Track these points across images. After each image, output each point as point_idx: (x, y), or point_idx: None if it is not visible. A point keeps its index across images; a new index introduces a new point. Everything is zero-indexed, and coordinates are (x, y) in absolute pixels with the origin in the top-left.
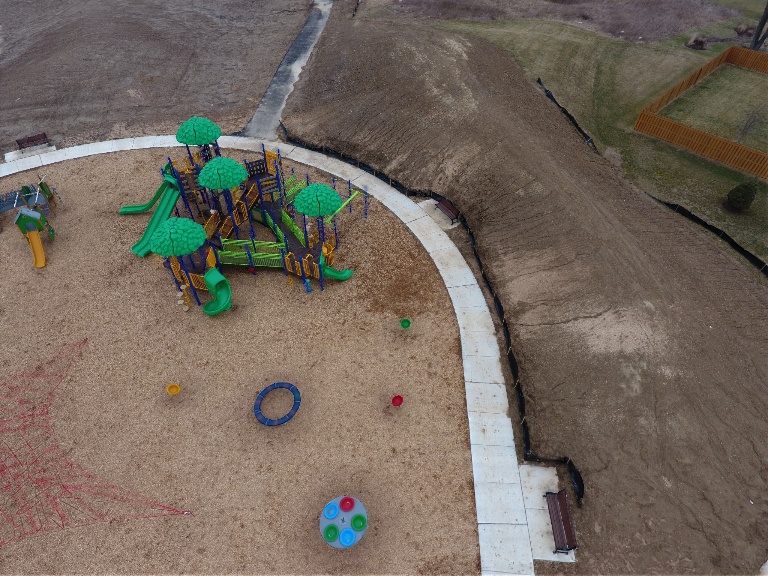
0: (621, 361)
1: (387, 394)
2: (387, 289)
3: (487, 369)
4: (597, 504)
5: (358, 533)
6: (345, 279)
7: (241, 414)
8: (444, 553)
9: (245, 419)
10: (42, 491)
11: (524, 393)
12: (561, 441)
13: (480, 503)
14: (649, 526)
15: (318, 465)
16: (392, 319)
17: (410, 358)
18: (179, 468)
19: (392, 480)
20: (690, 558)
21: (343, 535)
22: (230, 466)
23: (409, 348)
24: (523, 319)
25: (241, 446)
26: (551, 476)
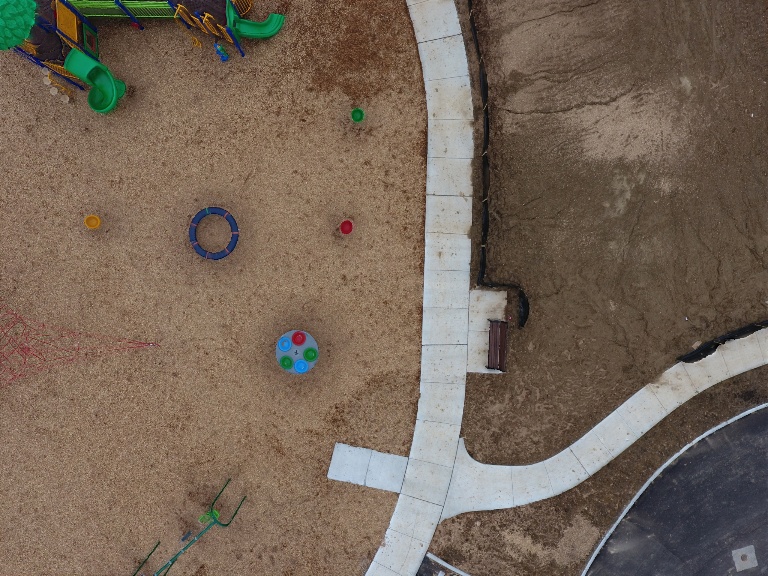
0: (616, 173)
1: (336, 213)
2: (333, 49)
3: (454, 177)
4: (537, 327)
5: (311, 363)
6: (272, 34)
7: (178, 244)
8: (389, 369)
9: (183, 249)
10: (8, 329)
11: (492, 208)
12: (519, 265)
13: (426, 327)
14: (579, 345)
15: (268, 296)
16: (341, 103)
17: (363, 163)
18: (131, 303)
19: (343, 307)
20: (605, 369)
21: (297, 364)
22: (181, 300)
23: (362, 149)
24: (512, 102)
25: (186, 280)
26: (500, 300)
